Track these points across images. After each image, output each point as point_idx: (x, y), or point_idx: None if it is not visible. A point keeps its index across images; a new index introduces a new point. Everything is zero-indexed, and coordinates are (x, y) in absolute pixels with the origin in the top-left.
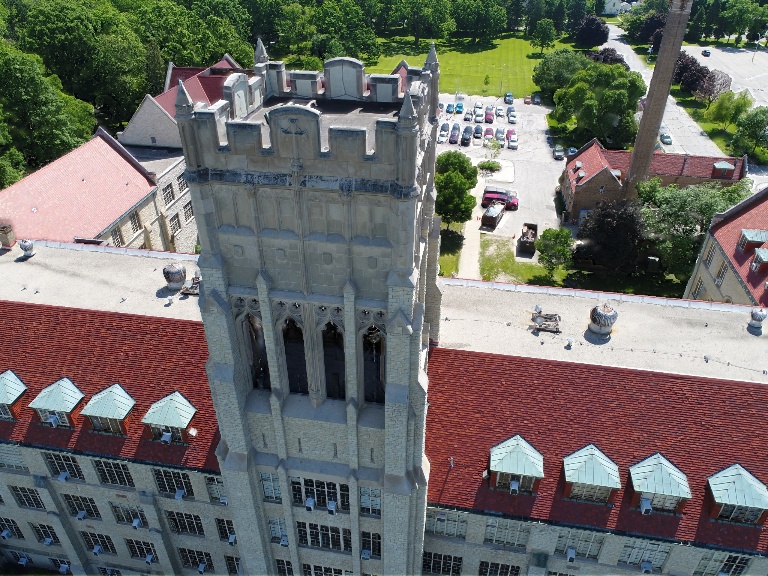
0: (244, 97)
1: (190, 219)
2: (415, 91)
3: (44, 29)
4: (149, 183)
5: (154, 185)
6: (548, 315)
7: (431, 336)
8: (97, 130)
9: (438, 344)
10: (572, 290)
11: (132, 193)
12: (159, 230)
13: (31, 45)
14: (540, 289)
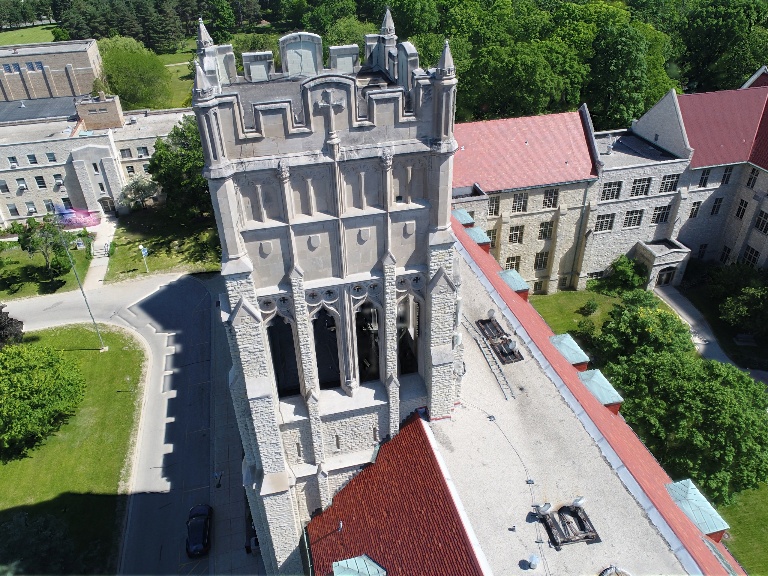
0: (313, 58)
1: (632, 227)
2: (305, 80)
3: (703, 11)
4: (592, 171)
5: (596, 175)
6: (586, 523)
7: (428, 406)
8: (582, 106)
9: (431, 421)
10: (679, 541)
11: (565, 172)
12: (578, 218)
13: (683, 25)
14: (643, 498)
